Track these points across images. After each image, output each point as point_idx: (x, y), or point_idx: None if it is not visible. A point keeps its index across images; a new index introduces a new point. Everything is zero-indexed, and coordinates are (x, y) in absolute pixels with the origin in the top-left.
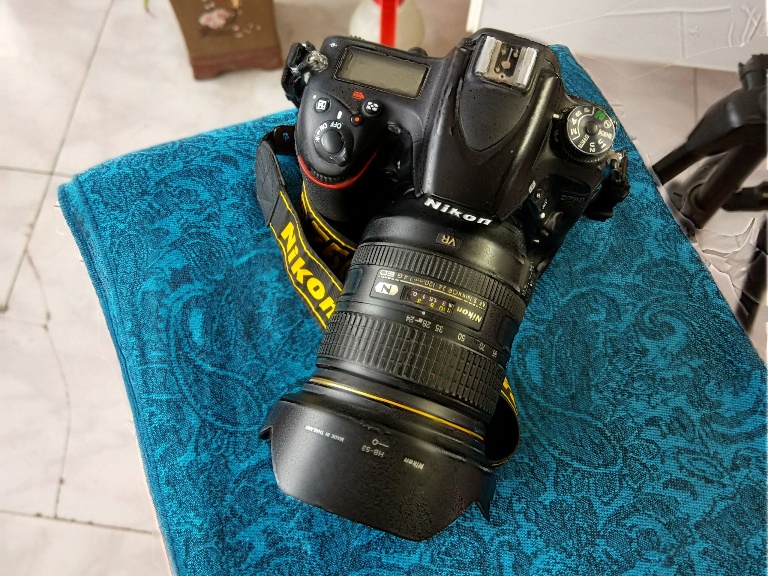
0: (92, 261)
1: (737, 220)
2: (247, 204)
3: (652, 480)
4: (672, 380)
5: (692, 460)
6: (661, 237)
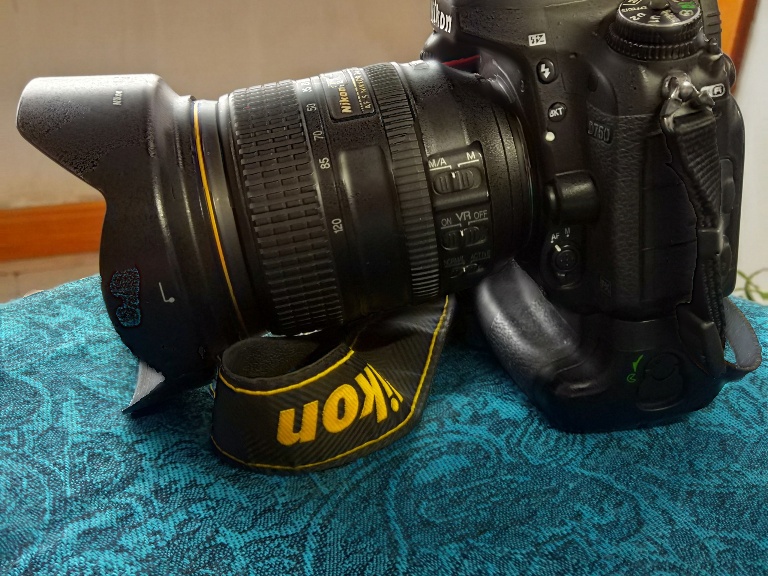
0: None
1: None
2: None
3: None
4: None
5: None
6: None
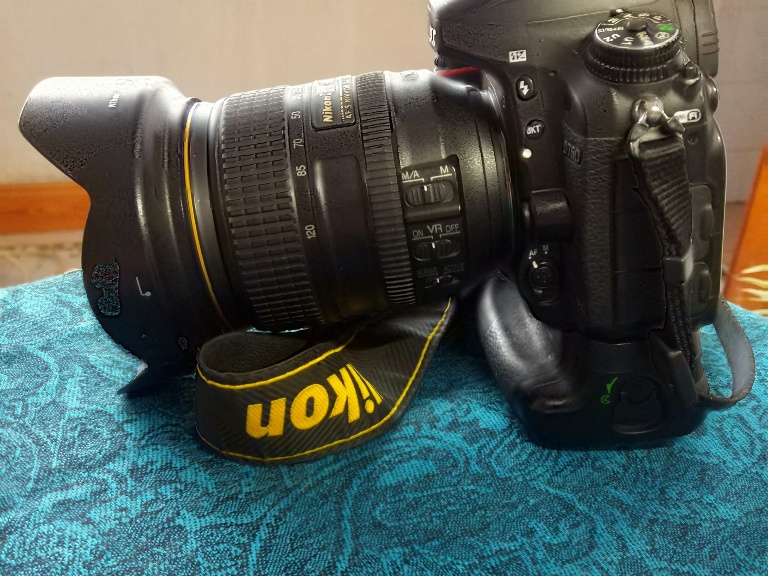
0: None
1: None
2: None
3: None
4: None
5: None
6: None
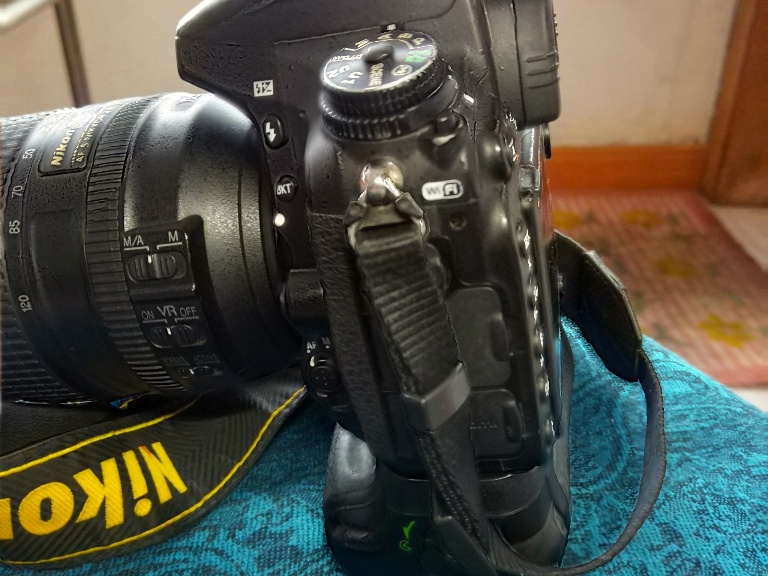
0: None
1: None
2: None
3: None
4: None
5: None
6: None
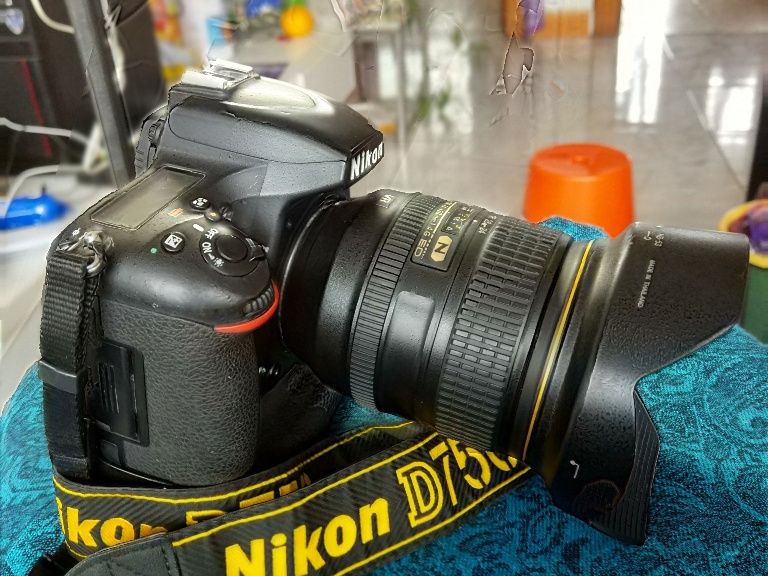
0: None
1: None
2: None
3: None
4: None
5: None
6: None
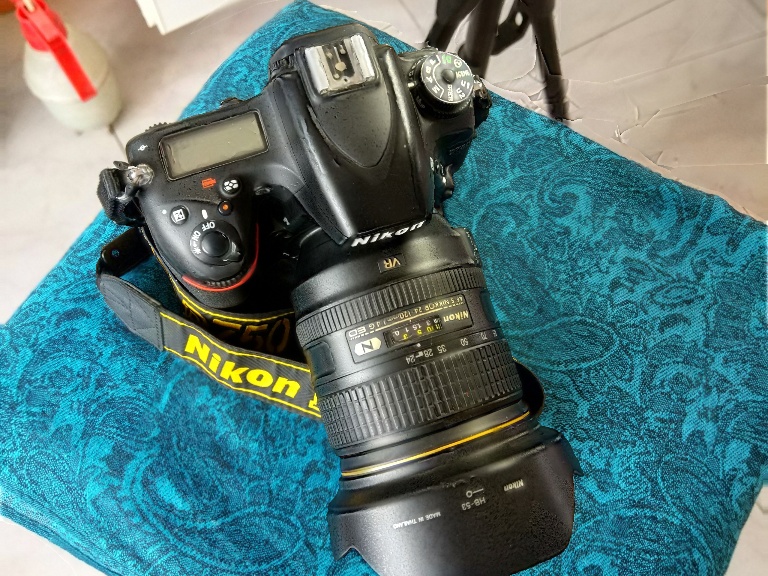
0: (10, 508)
1: (509, 58)
2: (126, 344)
3: (648, 333)
4: (604, 239)
5: (665, 294)
6: (509, 122)
